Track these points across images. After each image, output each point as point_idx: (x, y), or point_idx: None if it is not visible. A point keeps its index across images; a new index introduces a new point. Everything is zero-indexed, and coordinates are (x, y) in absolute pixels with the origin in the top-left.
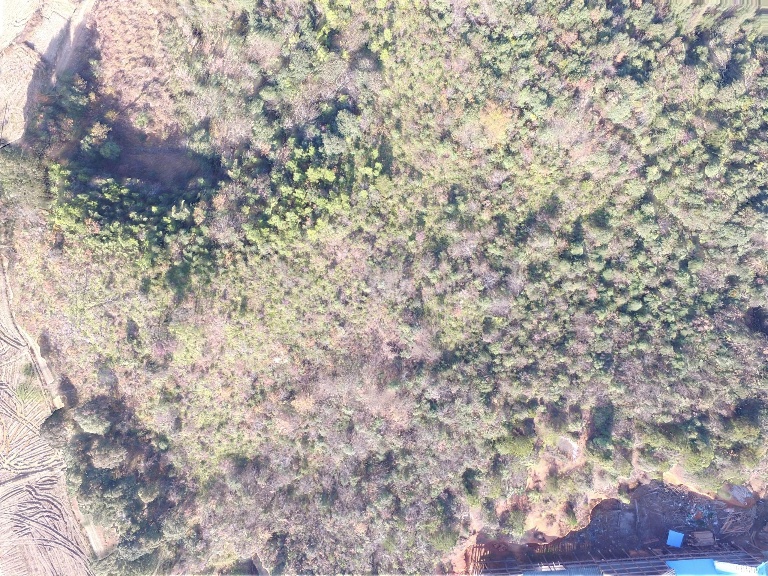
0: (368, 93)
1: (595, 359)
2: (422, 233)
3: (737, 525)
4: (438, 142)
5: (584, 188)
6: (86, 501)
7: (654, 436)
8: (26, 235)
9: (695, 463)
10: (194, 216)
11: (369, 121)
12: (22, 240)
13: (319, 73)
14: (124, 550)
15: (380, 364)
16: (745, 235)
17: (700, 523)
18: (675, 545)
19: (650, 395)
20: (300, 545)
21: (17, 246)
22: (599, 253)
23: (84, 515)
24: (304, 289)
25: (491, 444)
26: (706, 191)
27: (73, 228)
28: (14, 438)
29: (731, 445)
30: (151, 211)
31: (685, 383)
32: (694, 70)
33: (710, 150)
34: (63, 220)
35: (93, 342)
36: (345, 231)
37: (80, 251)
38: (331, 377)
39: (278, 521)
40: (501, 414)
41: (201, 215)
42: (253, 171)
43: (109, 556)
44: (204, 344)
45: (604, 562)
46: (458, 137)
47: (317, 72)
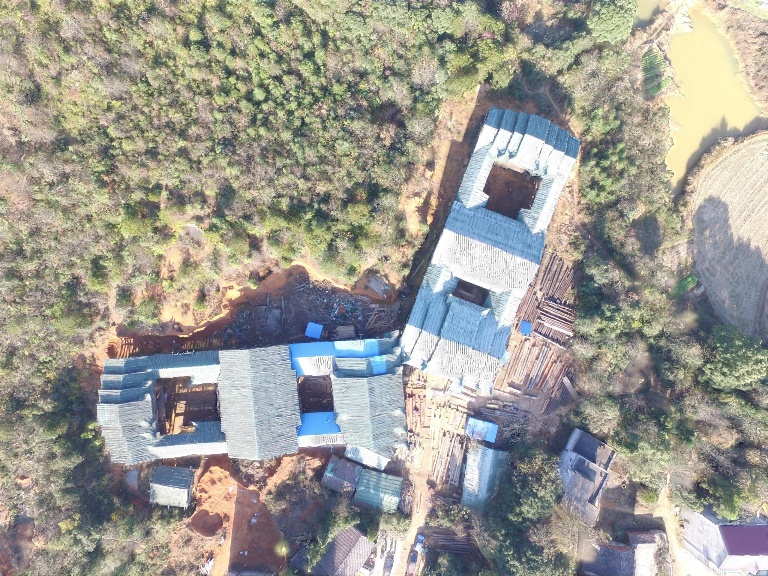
0: None
1: (216, 144)
2: (37, 17)
3: (381, 320)
4: None
5: None
6: None
7: (268, 216)
8: None
9: (309, 242)
10: None
11: None
12: None
13: None
14: None
15: (2, 149)
16: (364, 23)
17: (343, 318)
18: (313, 336)
19: (266, 176)
20: None
21: None
22: (217, 39)
23: None
24: None
25: (116, 229)
26: None
27: None
28: None
29: (352, 228)
30: None
31: (306, 168)
32: None
33: None
34: None
35: None
36: None
37: None
38: None
39: None
40: (118, 195)
41: None
42: None
43: None
44: None
45: None
46: None
47: None
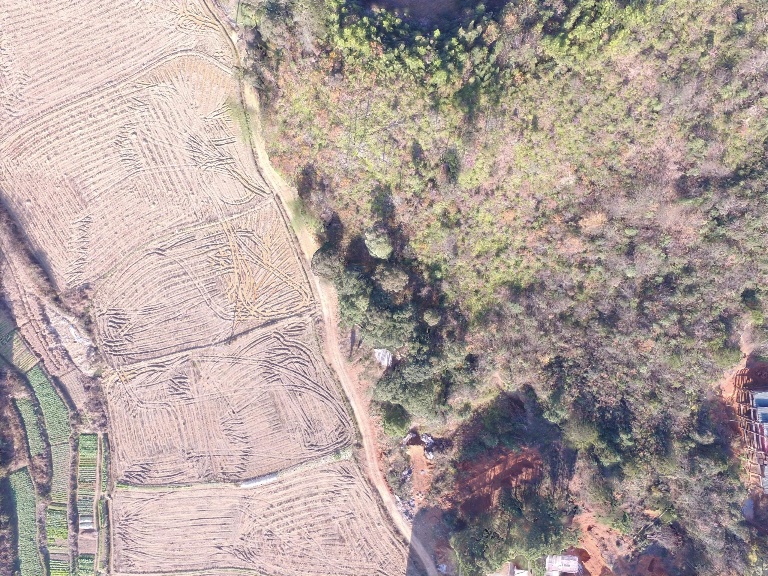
0: None
1: None
2: (711, 51)
3: None
4: None
5: None
6: (381, 319)
7: None
8: (292, 69)
9: None
10: (484, 36)
11: None
12: (290, 73)
13: None
14: (417, 368)
15: (666, 183)
16: None
17: None
18: None
19: None
20: (578, 368)
21: (282, 81)
22: None
23: (335, 359)
24: (595, 107)
25: None
26: None
27: (356, 52)
28: (261, 285)
29: None
30: (433, 36)
31: None
32: None
33: None
34: (350, 42)
35: (371, 170)
36: (638, 48)
37: (363, 75)
38: (615, 198)
39: (555, 346)
40: None
41: (493, 34)
42: None
43: (394, 379)
44: (492, 165)
45: None
46: None
47: None
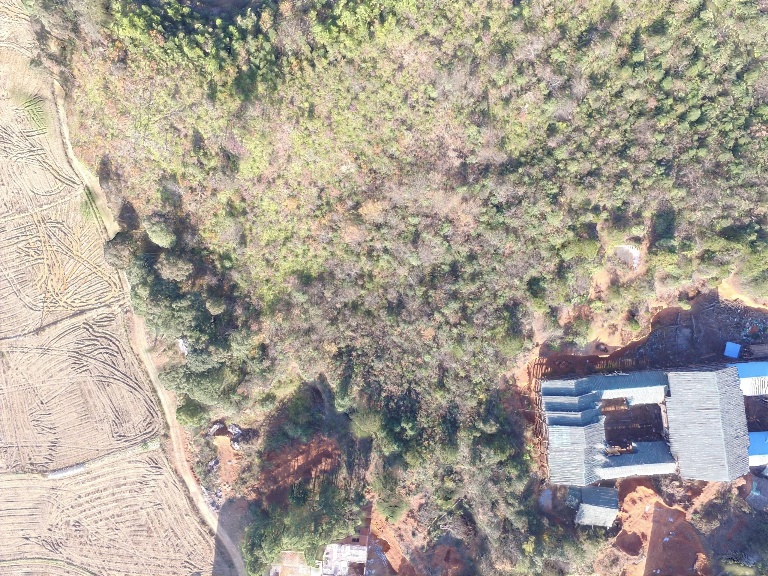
0: None
1: (656, 165)
2: (487, 38)
3: None
4: None
5: None
6: (156, 307)
7: (715, 237)
8: (86, 59)
9: (755, 263)
10: (260, 24)
11: None
12: (82, 63)
13: None
14: (194, 357)
15: (446, 170)
16: None
17: (755, 337)
18: (732, 356)
19: (711, 198)
20: (366, 358)
21: (76, 71)
22: (660, 60)
23: (143, 350)
24: (371, 95)
25: (555, 250)
26: (762, 1)
27: (137, 41)
28: (70, 276)
29: None
30: (215, 25)
31: (744, 188)
32: None
33: None
34: (128, 31)
35: (157, 159)
36: (412, 34)
37: (144, 64)
38: (397, 186)
39: (344, 335)
40: (566, 217)
41: (268, 22)
42: None
43: (177, 369)
44: (271, 153)
45: (665, 369)
46: None
47: None
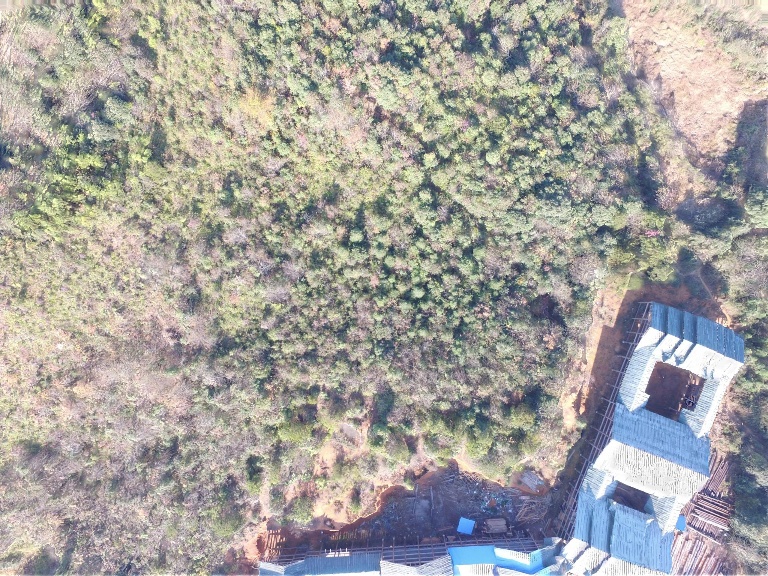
0: (140, 80)
1: (375, 346)
2: (198, 220)
3: (532, 512)
4: (209, 129)
5: (363, 175)
6: None
7: (431, 422)
8: None
9: (472, 449)
10: None
11: (141, 108)
12: None
13: (92, 60)
14: None
15: (160, 350)
16: (526, 222)
17: (494, 510)
18: (466, 532)
19: (428, 382)
20: (89, 531)
21: None
22: (378, 240)
23: None
24: (82, 276)
25: (273, 430)
26: (487, 178)
27: None
28: None
29: (512, 432)
30: None
31: (466, 370)
32: (472, 57)
33: (493, 137)
34: None
35: None
36: (120, 218)
37: None
38: (115, 364)
39: (69, 507)
40: (279, 400)
41: None
42: (31, 158)
43: None
44: None
45: (391, 548)
46: (229, 124)
47: (90, 59)
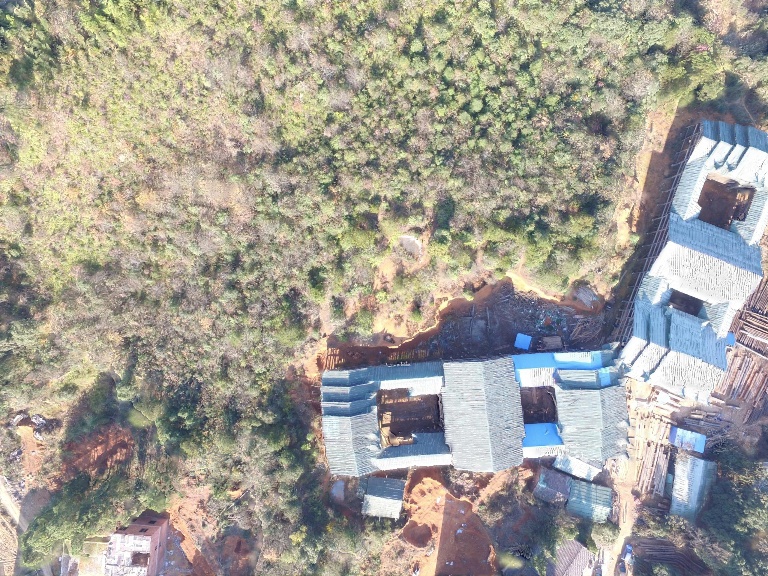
0: None
1: (436, 155)
2: (262, 27)
3: (586, 331)
4: None
5: None
6: None
7: (492, 228)
8: None
9: (532, 254)
10: (36, 13)
11: None
12: None
13: None
14: None
15: (223, 160)
16: (582, 35)
17: (549, 328)
18: (523, 347)
19: (488, 188)
20: (150, 347)
21: None
22: (438, 50)
23: None
24: (146, 84)
25: (335, 241)
26: None
27: None
28: None
29: (570, 240)
30: None
31: (525, 179)
32: None
33: None
34: None
35: None
36: (184, 24)
37: None
38: (177, 176)
39: (129, 325)
40: (342, 207)
41: (42, 11)
42: None
43: None
44: (48, 142)
45: None
46: None
47: None
